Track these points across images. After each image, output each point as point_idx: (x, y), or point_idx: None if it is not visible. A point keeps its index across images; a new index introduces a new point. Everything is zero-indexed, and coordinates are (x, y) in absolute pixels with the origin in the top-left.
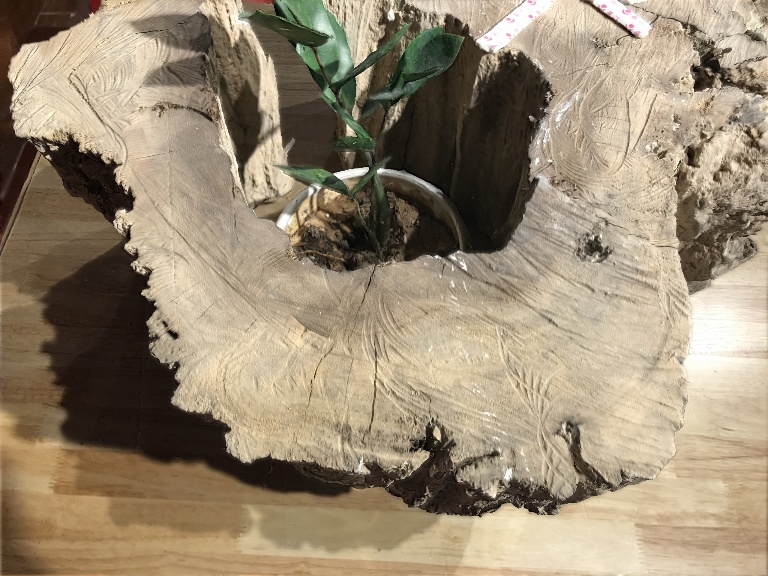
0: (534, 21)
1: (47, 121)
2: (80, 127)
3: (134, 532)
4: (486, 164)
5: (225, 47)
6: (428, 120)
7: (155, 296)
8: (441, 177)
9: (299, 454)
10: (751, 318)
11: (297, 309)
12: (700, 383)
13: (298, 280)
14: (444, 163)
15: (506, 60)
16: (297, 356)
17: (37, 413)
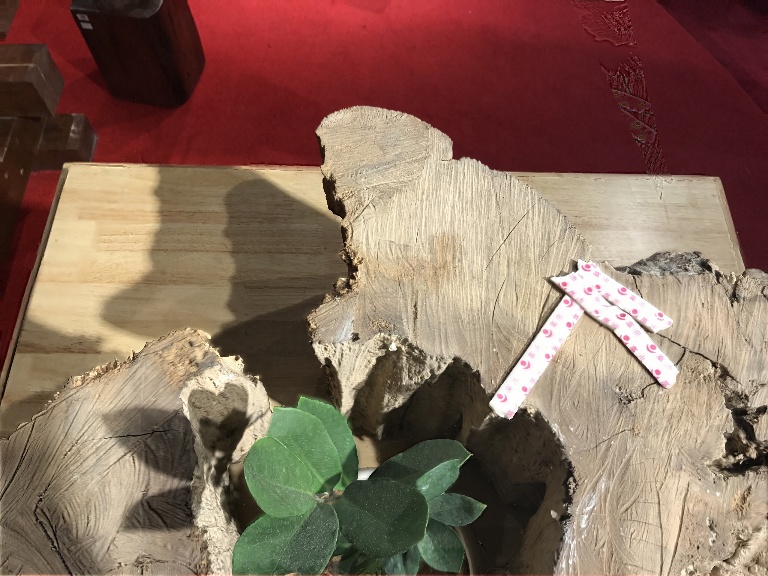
0: (551, 361)
1: None
2: None
3: None
4: (494, 451)
5: (209, 399)
6: (431, 403)
7: None
8: (443, 431)
9: None
10: None
11: None
12: None
13: None
14: (447, 425)
15: (521, 411)
16: None
17: None
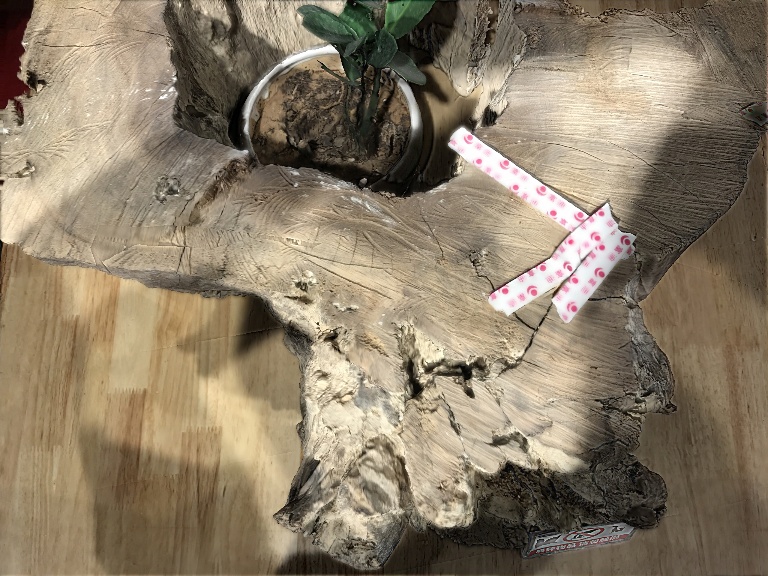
0: (512, 192)
1: None
2: None
3: None
4: None
5: None
6: None
7: None
8: None
9: (34, 7)
10: None
11: None
12: (271, 474)
13: None
14: None
15: None
16: None
17: None
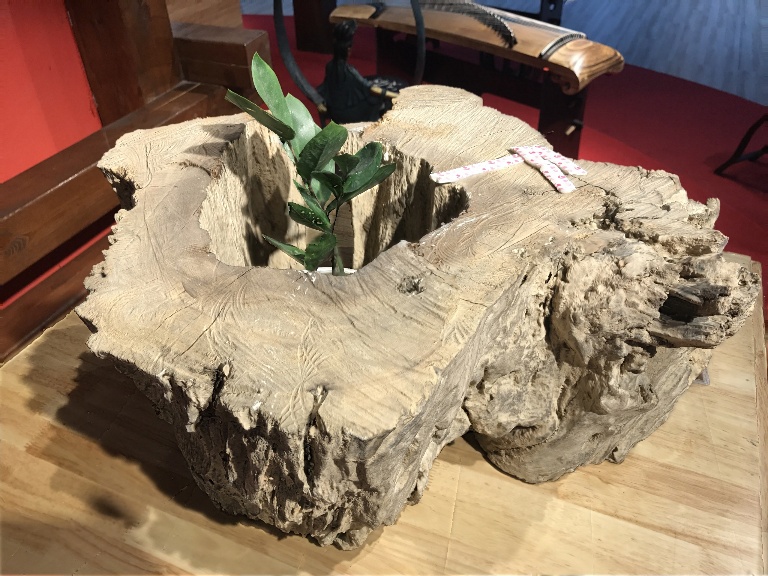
0: (486, 173)
1: (118, 161)
2: (134, 167)
3: (59, 497)
4: None
5: (264, 157)
6: None
7: (108, 253)
8: None
9: (128, 355)
10: (694, 503)
11: (187, 279)
12: (611, 544)
13: (198, 263)
14: None
15: (453, 193)
16: (168, 303)
17: (50, 396)
